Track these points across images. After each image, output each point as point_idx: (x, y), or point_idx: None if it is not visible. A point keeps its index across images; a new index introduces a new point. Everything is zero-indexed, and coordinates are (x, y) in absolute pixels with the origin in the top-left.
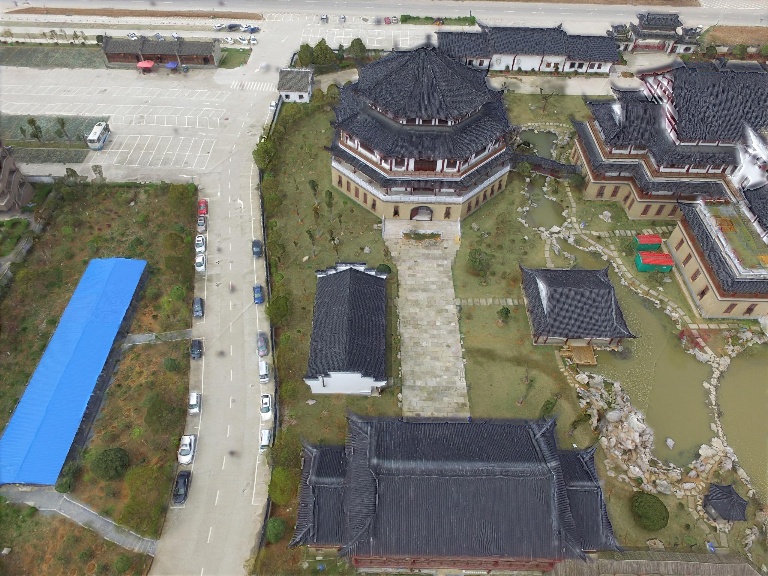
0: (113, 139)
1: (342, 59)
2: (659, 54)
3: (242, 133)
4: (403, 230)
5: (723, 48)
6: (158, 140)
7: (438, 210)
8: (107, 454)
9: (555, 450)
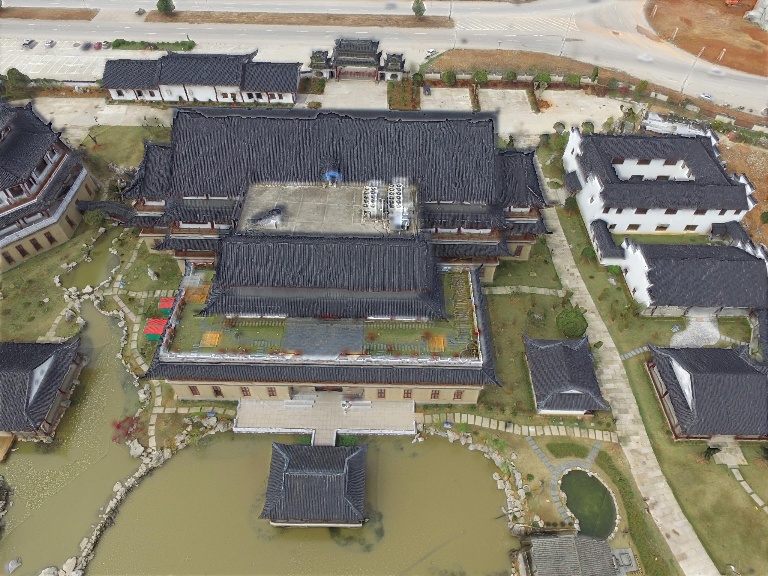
0: None
1: (2, 90)
2: (368, 81)
3: None
4: None
5: (435, 75)
6: None
7: None
8: None
9: None
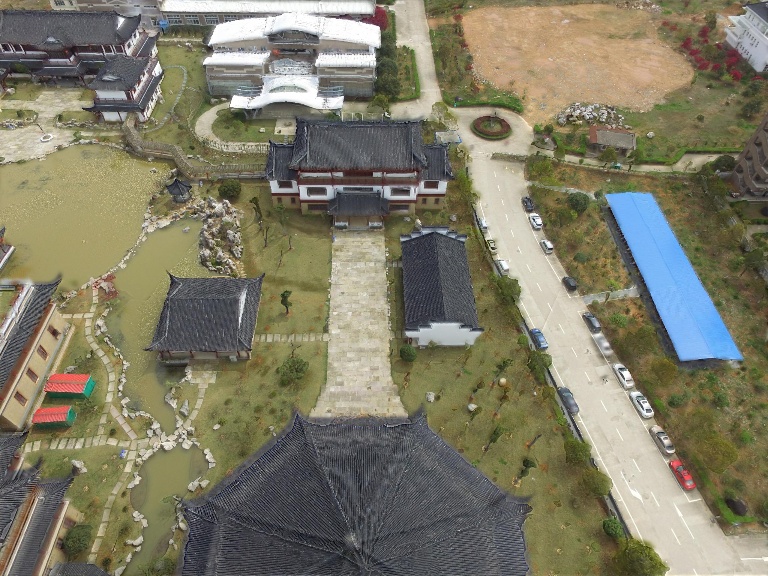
0: None
1: None
2: None
3: None
4: None
5: None
6: None
7: None
8: (582, 199)
9: None
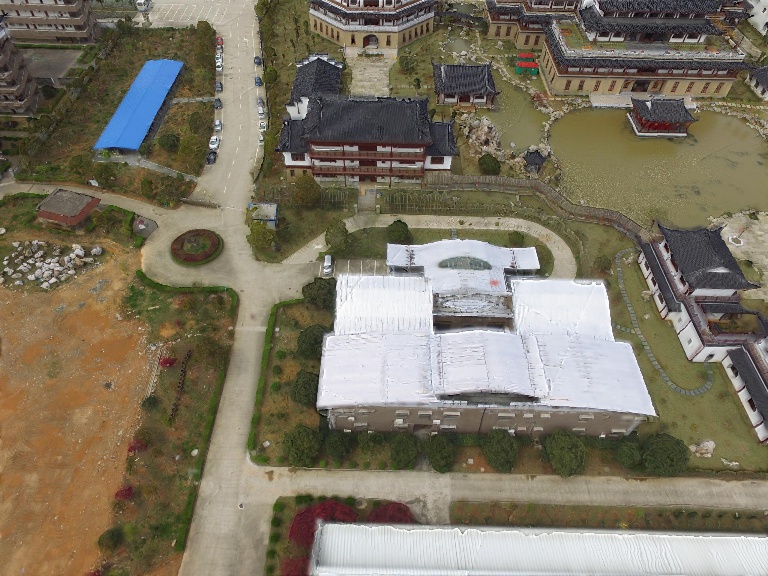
0: (154, 6)
1: None
2: None
3: (247, 4)
4: (357, 51)
5: None
6: (186, 7)
7: (382, 38)
8: (168, 134)
9: (426, 110)
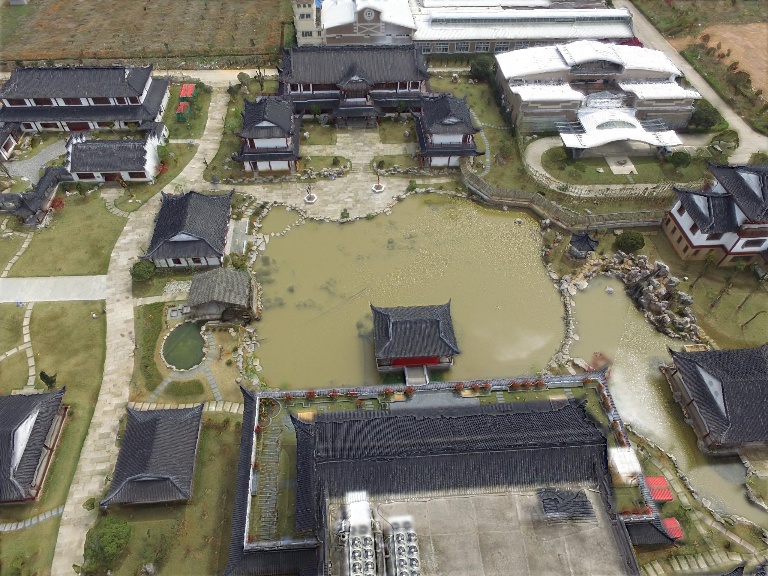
0: None
1: None
2: None
3: None
4: None
5: None
6: None
7: None
8: None
9: (747, 210)
